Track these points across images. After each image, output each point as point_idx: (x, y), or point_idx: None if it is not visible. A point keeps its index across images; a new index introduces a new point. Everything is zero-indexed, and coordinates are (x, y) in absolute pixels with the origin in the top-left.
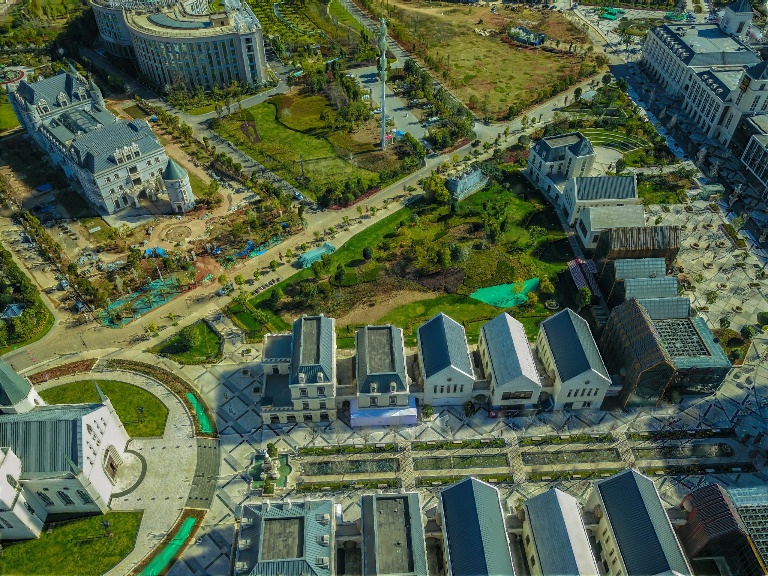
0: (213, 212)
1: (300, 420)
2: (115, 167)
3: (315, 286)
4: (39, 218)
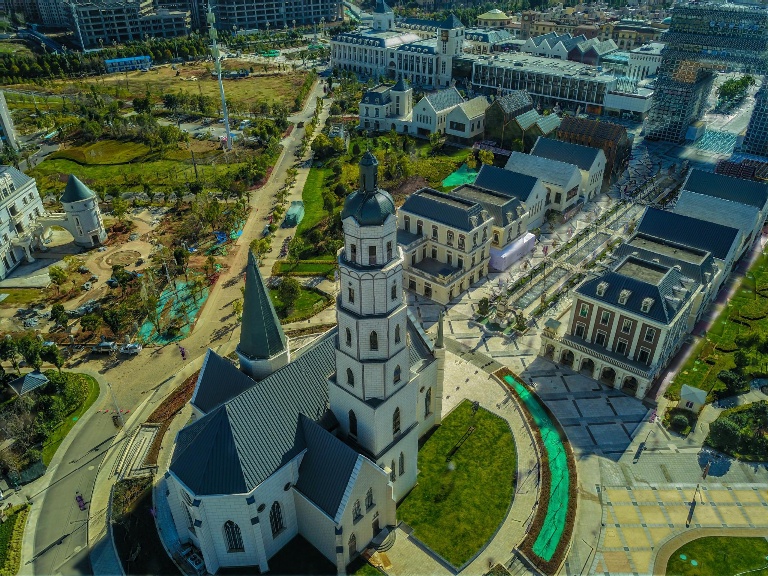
0: (136, 232)
1: (467, 286)
2: None
3: None
4: None
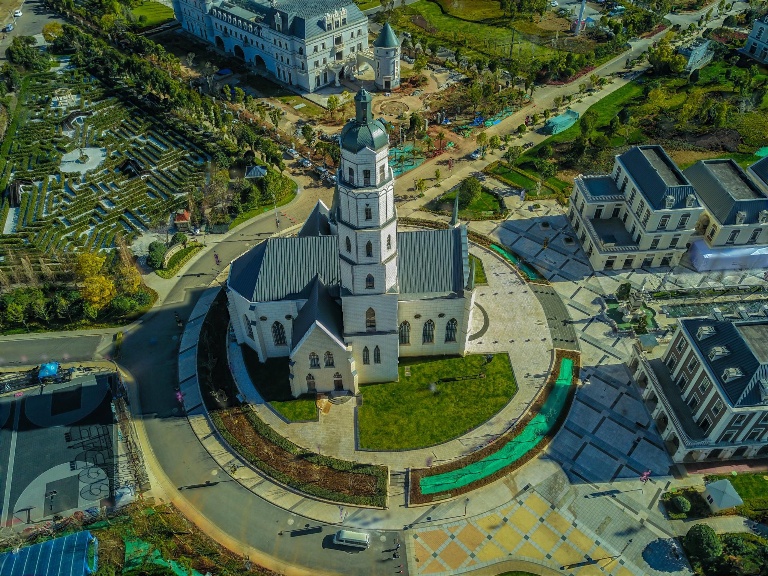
0: (423, 89)
1: (638, 265)
2: (324, 34)
3: None
4: (231, 98)
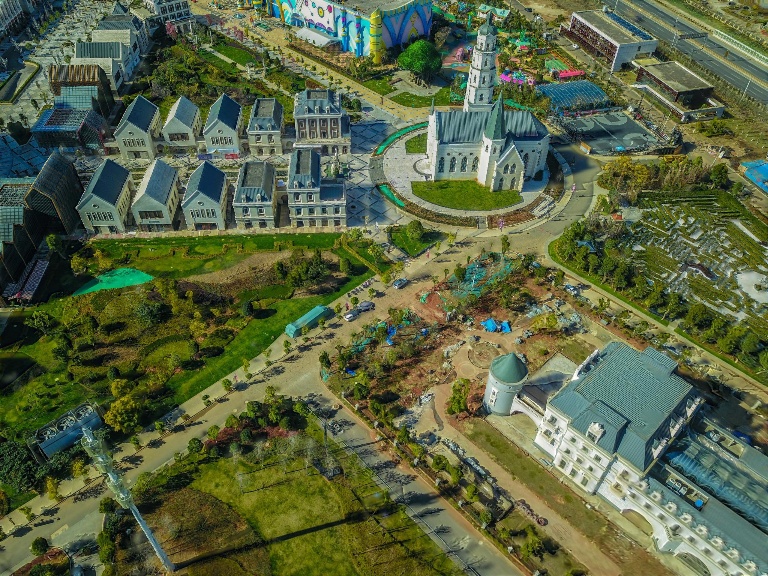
0: None
1: None
2: None
3: (308, 272)
4: None
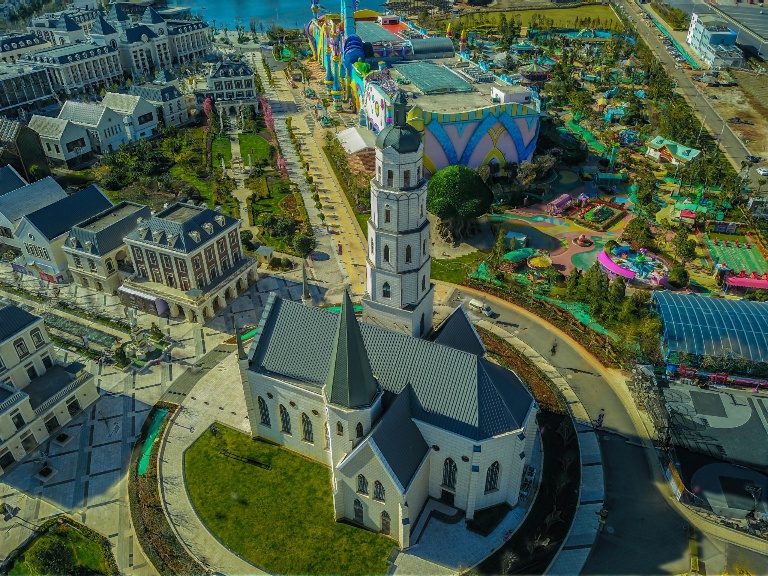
0: None
1: None
2: None
3: None
4: None
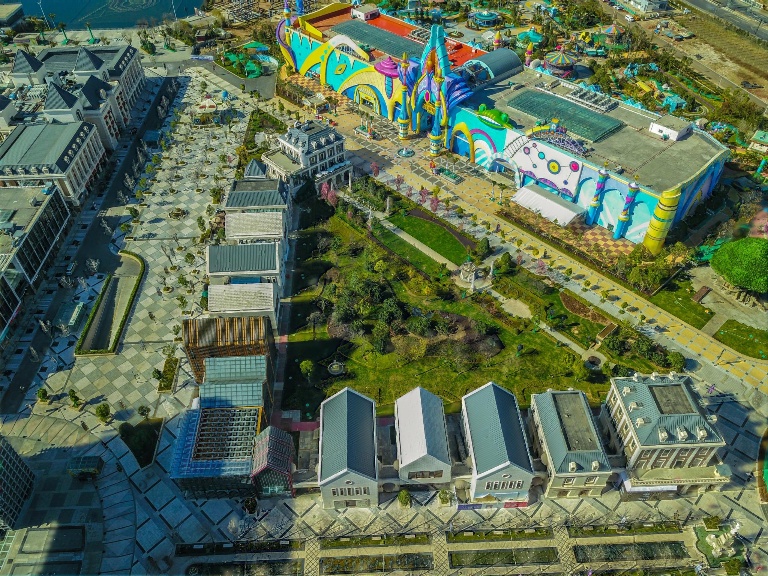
0: None
1: None
2: None
3: None
4: None
